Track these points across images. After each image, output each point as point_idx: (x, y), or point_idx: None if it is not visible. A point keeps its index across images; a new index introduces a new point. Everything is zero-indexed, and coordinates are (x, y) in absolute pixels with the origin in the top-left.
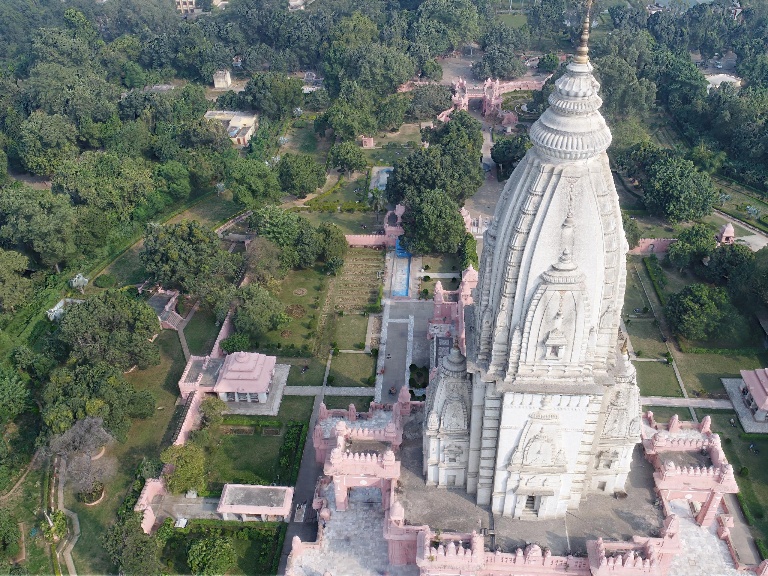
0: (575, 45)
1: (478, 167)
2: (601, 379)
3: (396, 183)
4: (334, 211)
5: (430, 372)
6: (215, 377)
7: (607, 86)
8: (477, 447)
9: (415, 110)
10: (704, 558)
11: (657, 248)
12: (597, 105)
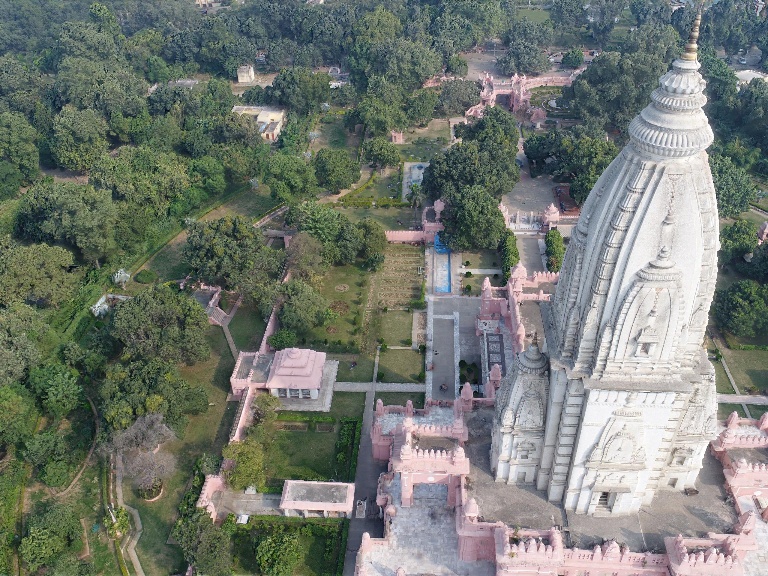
0: (598, 41)
1: (514, 163)
2: (688, 376)
3: (433, 179)
4: (369, 207)
5: (482, 368)
6: (266, 373)
7: (639, 82)
8: (552, 444)
9: (444, 105)
10: None
11: None
12: (703, 102)
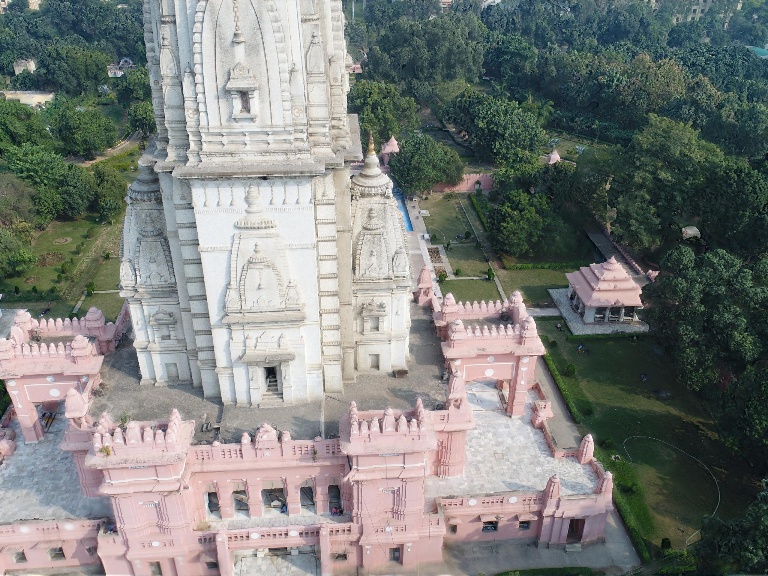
0: None
1: None
2: (324, 159)
3: None
4: (125, 169)
5: None
6: None
7: None
8: None
9: None
10: (514, 450)
11: (484, 185)
12: None
